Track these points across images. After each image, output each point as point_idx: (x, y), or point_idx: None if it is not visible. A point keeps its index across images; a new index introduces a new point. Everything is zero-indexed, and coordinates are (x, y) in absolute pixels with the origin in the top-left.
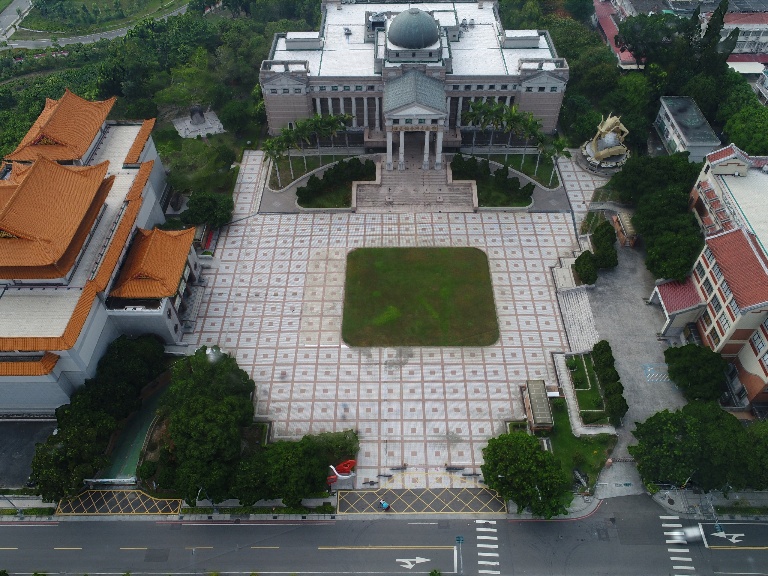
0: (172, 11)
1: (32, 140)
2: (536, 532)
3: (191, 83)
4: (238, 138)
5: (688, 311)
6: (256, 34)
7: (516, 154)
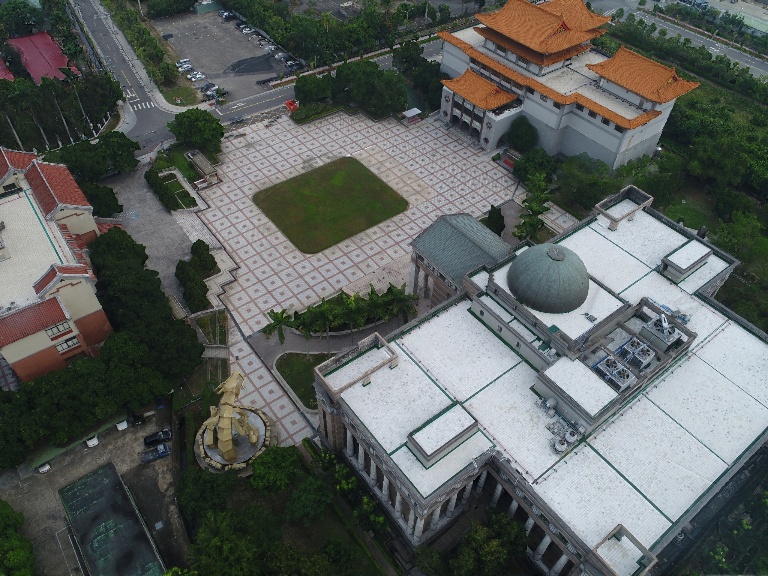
0: None
1: None
2: None
3: None
4: None
5: None
6: None
7: None
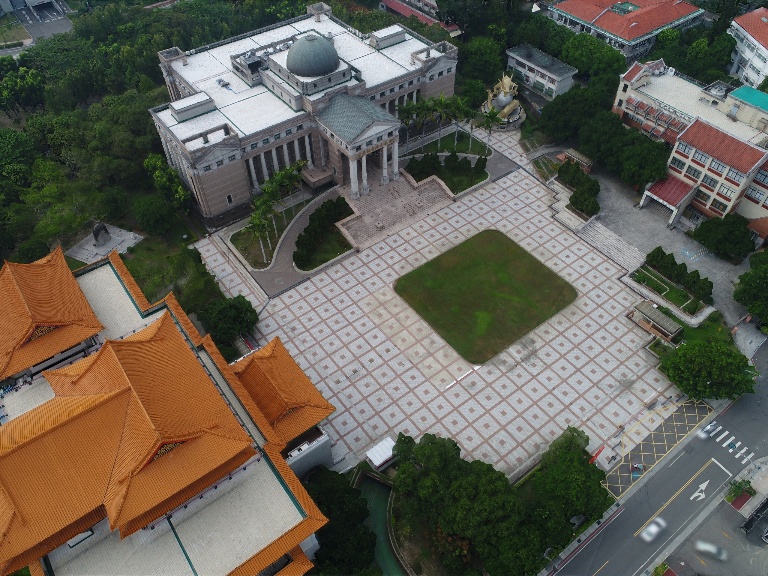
0: None
1: (20, 339)
2: (743, 409)
3: (63, 203)
4: (166, 238)
5: (688, 197)
6: (90, 123)
7: (436, 140)
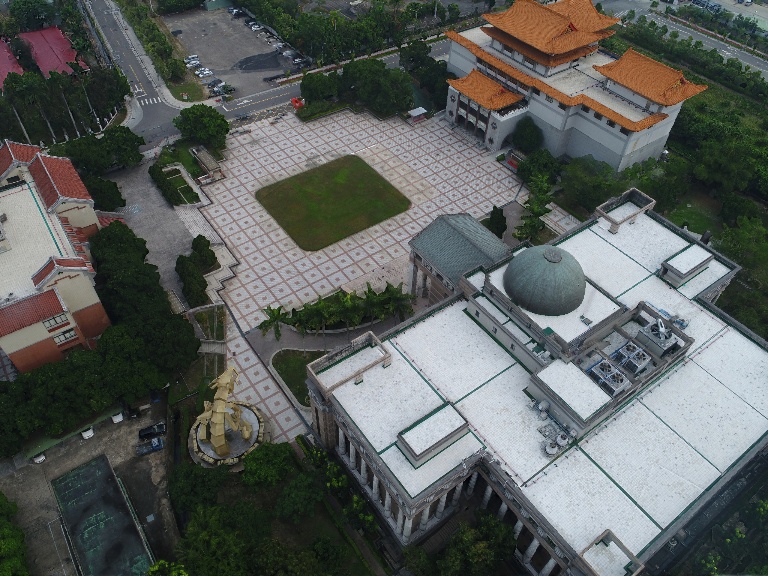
0: None
1: None
2: None
3: None
4: None
5: None
6: None
7: None
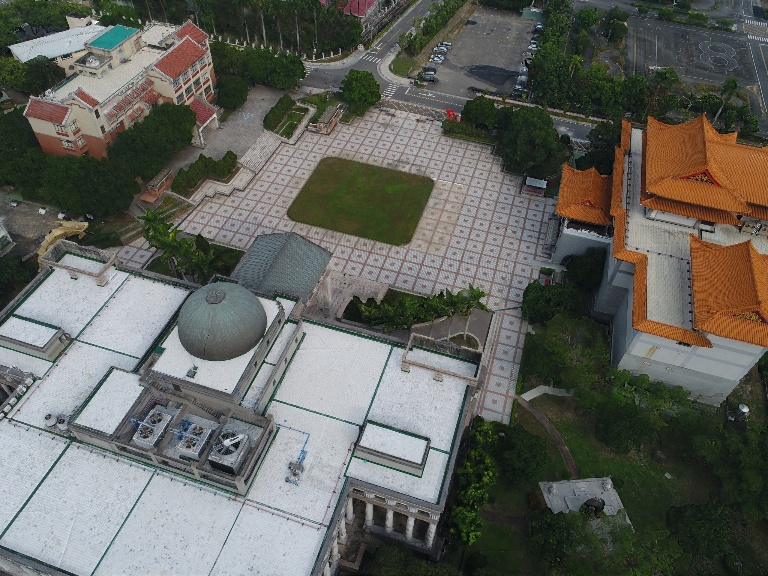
0: None
1: (760, 255)
2: None
3: None
4: None
5: None
6: None
7: None
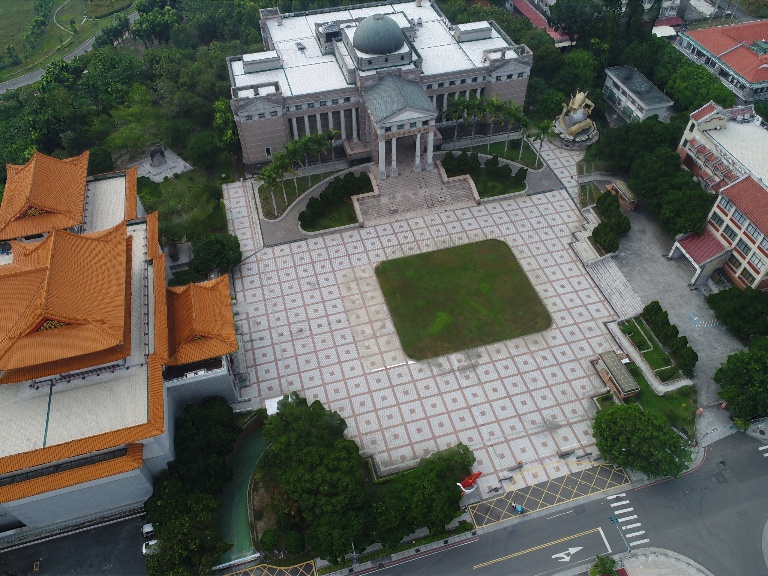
0: (73, 49)
1: (17, 213)
2: (664, 493)
3: (139, 123)
4: (209, 173)
5: (717, 258)
6: (191, 62)
7: (493, 143)
